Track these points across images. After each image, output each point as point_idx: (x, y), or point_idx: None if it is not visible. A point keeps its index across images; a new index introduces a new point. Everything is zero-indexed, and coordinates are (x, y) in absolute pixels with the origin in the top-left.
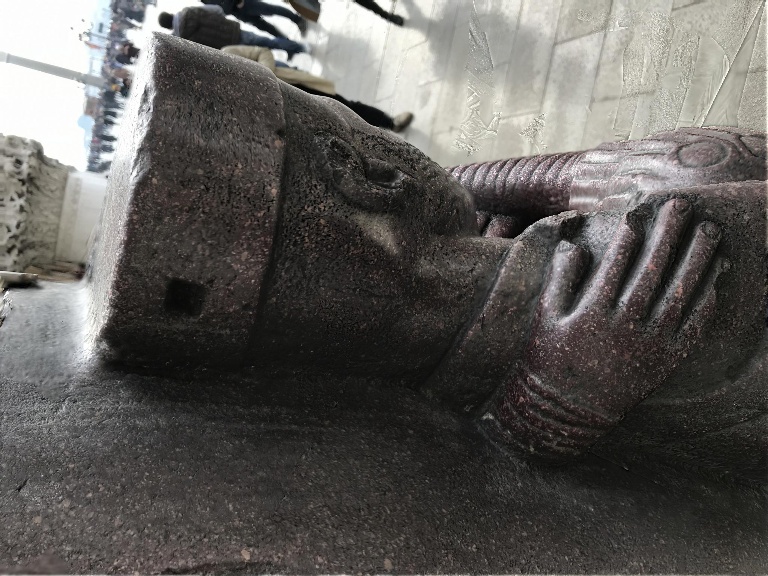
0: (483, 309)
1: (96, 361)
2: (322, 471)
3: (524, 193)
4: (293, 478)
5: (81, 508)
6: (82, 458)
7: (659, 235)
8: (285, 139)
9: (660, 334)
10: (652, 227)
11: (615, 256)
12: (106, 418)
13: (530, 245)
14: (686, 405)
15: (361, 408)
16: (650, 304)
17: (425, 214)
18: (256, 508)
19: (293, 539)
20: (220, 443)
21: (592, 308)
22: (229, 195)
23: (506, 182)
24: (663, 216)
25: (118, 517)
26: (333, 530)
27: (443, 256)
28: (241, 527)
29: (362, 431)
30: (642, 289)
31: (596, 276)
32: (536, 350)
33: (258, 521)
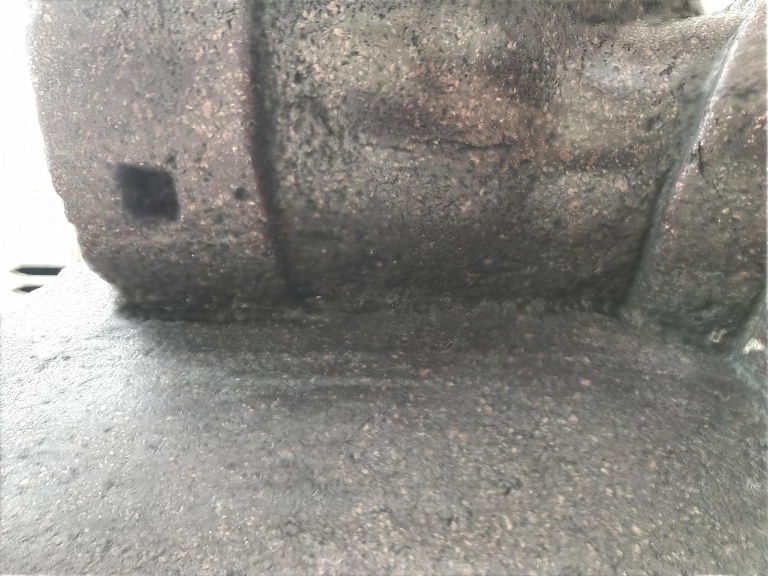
0: (697, 133)
1: (109, 307)
2: (392, 450)
3: None
4: (337, 462)
5: (6, 500)
6: (38, 431)
7: None
8: None
9: None
10: None
11: None
12: (93, 377)
13: None
14: None
15: (496, 347)
16: None
17: None
18: (261, 510)
19: (311, 567)
20: (236, 407)
21: None
22: (162, 16)
23: None
24: None
25: (48, 516)
26: (389, 556)
27: (605, 57)
28: (225, 541)
29: (486, 383)
30: None
31: None
32: None
33: (256, 532)
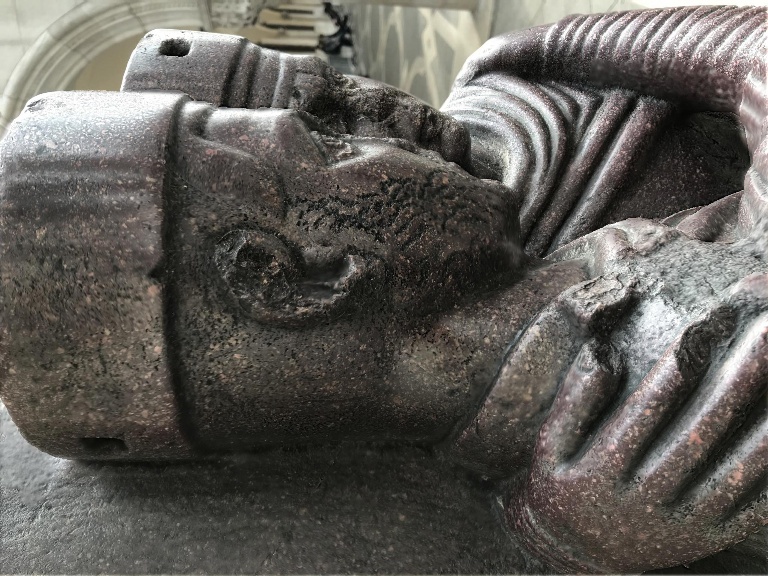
0: (477, 414)
1: None
2: None
3: (682, 76)
4: None
5: None
6: None
7: (722, 385)
8: (166, 276)
9: (694, 523)
10: (722, 358)
11: (642, 409)
12: (75, 527)
13: (549, 334)
14: (767, 545)
15: (349, 485)
16: (682, 488)
17: (396, 301)
18: None
19: None
20: (180, 551)
21: (595, 474)
22: (103, 365)
23: (658, 57)
24: (741, 348)
25: None
26: None
27: (427, 344)
28: None
29: (341, 521)
30: (671, 469)
31: (611, 428)
32: (531, 487)
33: None
